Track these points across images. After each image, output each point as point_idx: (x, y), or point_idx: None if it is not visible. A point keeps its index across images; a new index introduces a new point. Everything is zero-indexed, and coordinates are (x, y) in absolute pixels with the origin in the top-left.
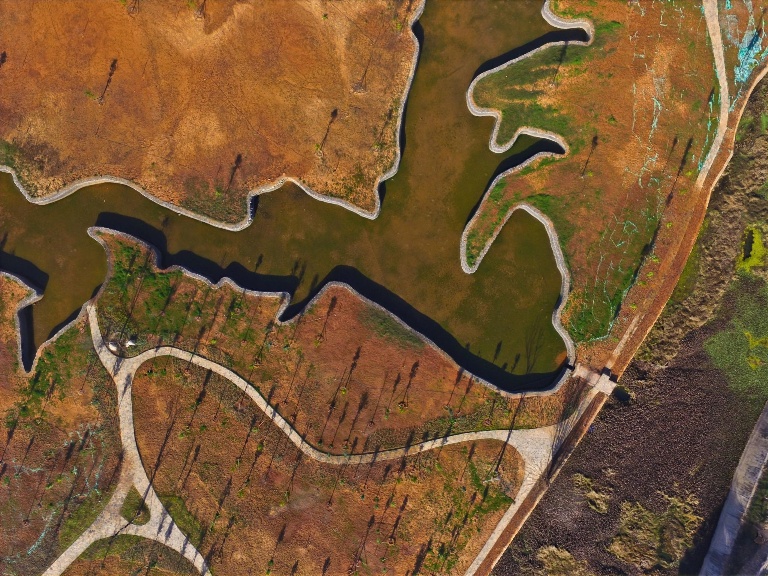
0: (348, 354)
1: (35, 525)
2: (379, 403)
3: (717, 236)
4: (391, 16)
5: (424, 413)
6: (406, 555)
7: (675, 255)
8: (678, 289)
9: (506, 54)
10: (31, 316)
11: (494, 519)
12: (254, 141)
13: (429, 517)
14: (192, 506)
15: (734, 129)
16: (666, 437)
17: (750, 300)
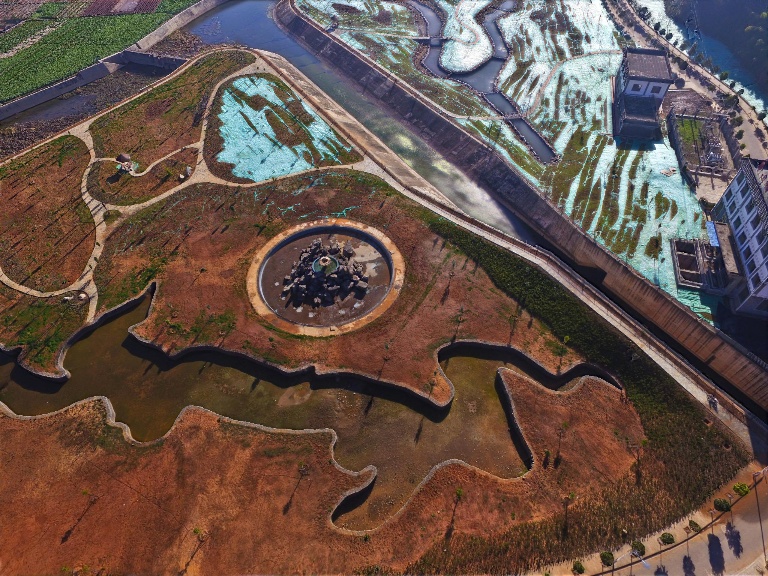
0: None
1: None
2: None
3: None
4: None
5: None
6: None
7: None
8: None
9: None
10: None
11: None
12: None
13: None
14: None
15: None
16: None
17: None
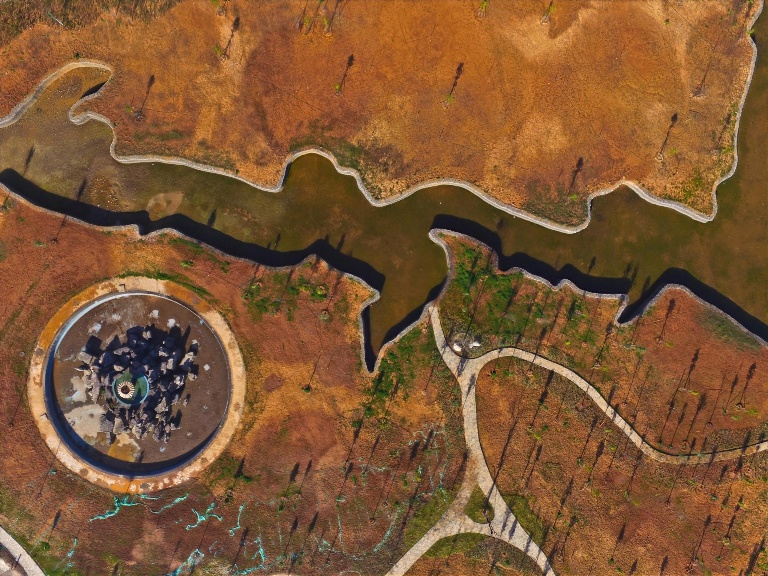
0: (687, 356)
1: (381, 523)
2: (717, 404)
3: None
4: (730, 21)
5: (760, 414)
6: (740, 554)
7: None
8: None
9: None
10: (368, 317)
11: None
12: (596, 145)
13: (762, 517)
14: (535, 505)
15: None
16: None
17: None
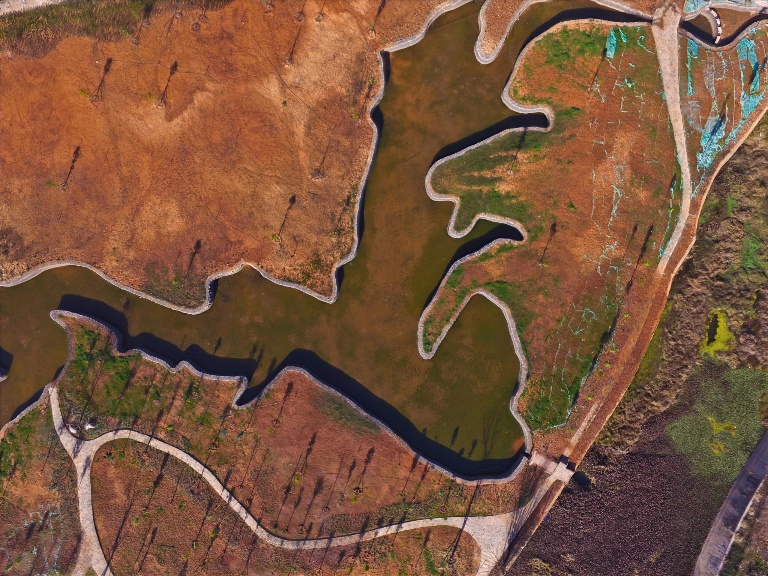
0: (304, 439)
1: None
2: (334, 488)
3: (680, 320)
4: (350, 103)
5: (379, 499)
6: None
7: (635, 342)
8: (640, 373)
9: (465, 139)
10: None
11: None
12: (213, 227)
13: None
14: None
15: (696, 215)
16: (627, 523)
17: (714, 385)
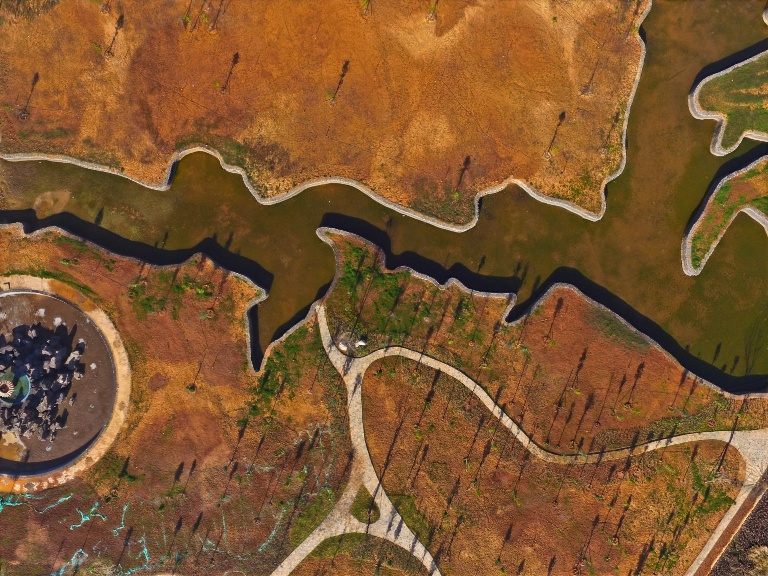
0: (575, 355)
1: (266, 523)
2: (605, 404)
3: None
4: (618, 19)
5: (649, 414)
6: (629, 554)
7: None
8: None
9: (727, 58)
10: (256, 315)
11: (714, 519)
12: (483, 143)
13: (651, 517)
14: (421, 505)
15: None
16: None
17: None
